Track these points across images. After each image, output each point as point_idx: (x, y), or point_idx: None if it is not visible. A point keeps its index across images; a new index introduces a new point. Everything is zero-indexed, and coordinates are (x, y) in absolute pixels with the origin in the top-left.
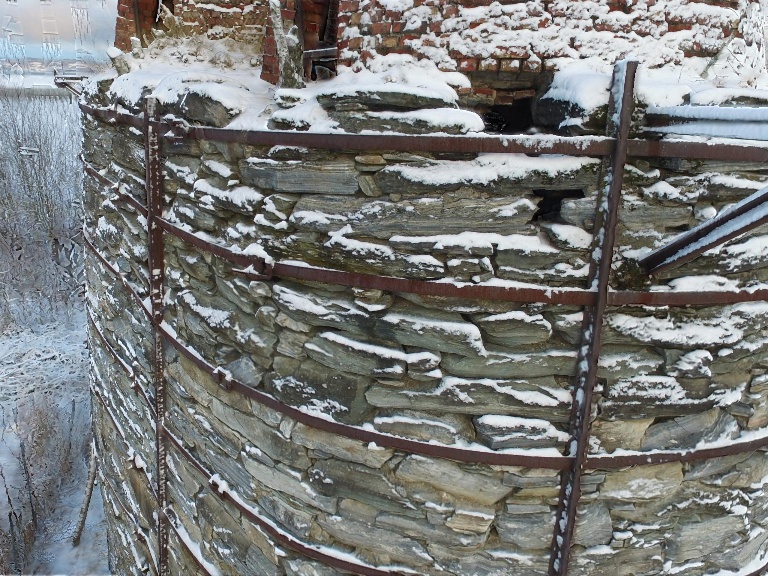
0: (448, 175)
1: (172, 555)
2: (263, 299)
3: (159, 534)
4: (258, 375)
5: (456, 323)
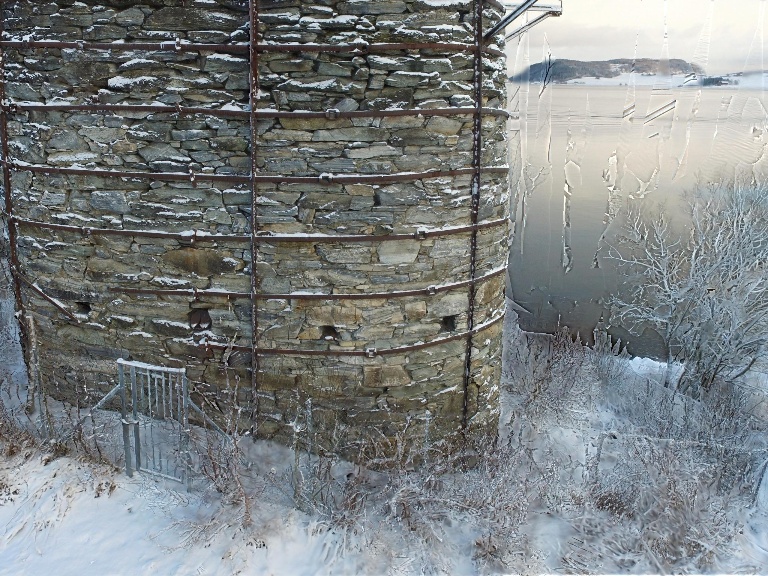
0: (438, 3)
1: (263, 263)
2: (360, 65)
3: (252, 253)
4: (358, 104)
5: (445, 59)
